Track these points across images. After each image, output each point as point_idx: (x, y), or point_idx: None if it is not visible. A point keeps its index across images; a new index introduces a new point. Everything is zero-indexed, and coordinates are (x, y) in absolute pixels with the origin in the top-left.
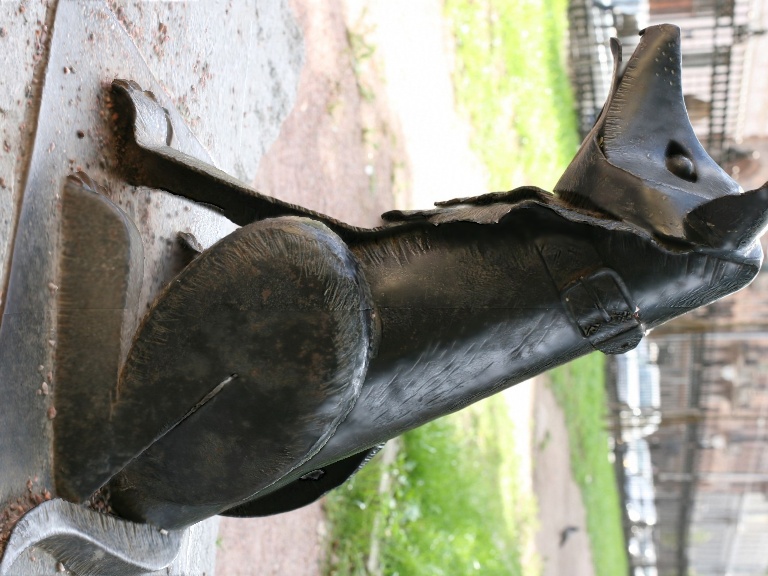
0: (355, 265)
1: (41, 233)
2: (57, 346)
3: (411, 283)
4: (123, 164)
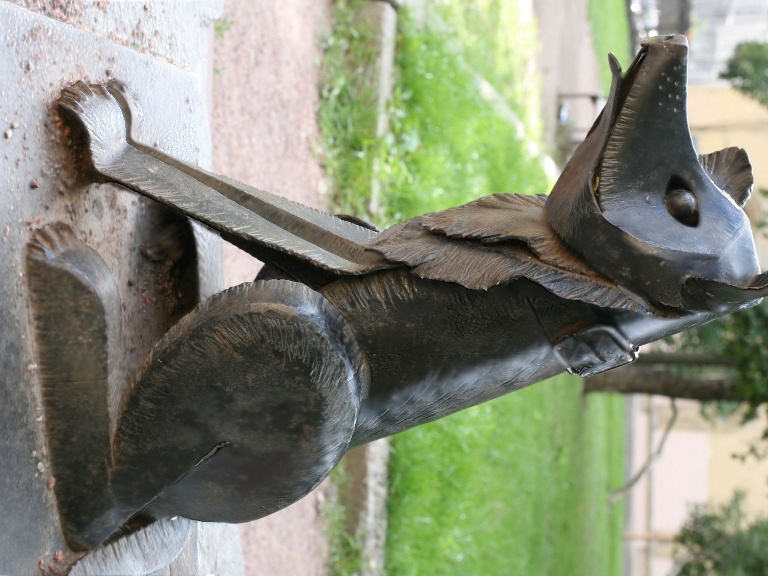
0: (340, 334)
1: (11, 327)
2: (46, 418)
3: (399, 330)
4: (83, 170)
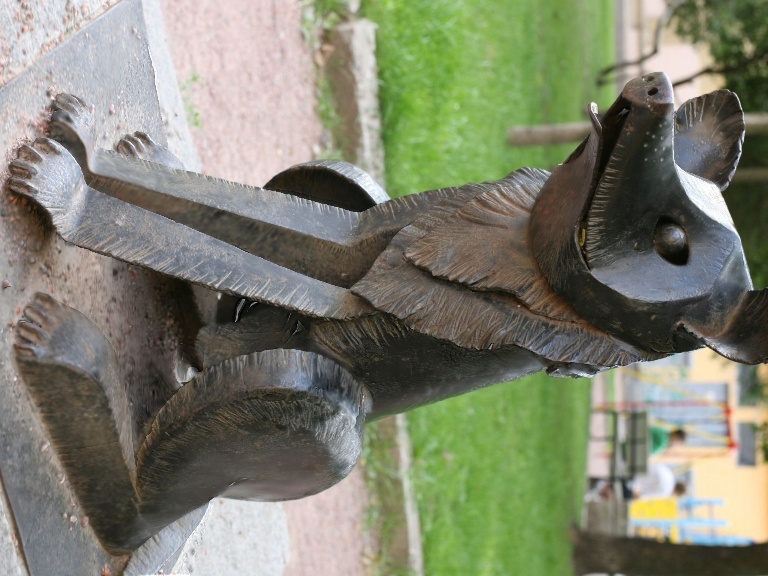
0: (338, 392)
1: (18, 433)
2: (68, 476)
3: (394, 363)
4: None
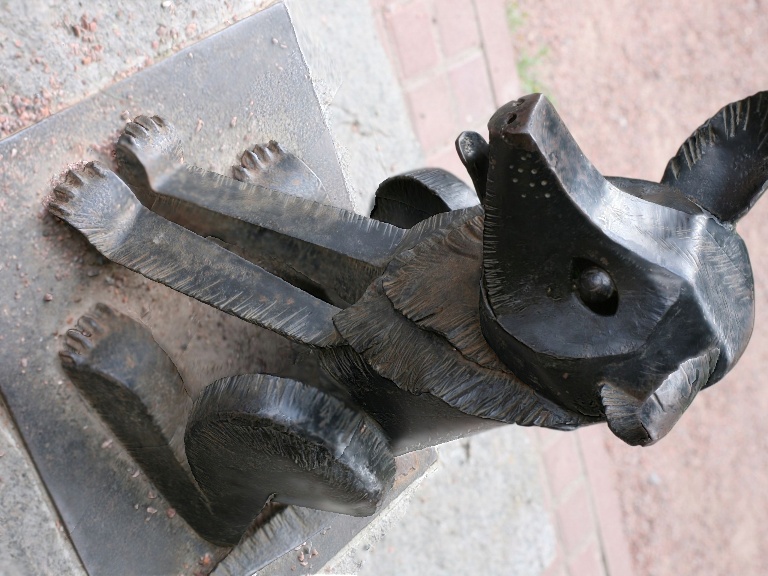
0: (313, 422)
1: (64, 431)
2: (143, 471)
3: (383, 395)
4: None
